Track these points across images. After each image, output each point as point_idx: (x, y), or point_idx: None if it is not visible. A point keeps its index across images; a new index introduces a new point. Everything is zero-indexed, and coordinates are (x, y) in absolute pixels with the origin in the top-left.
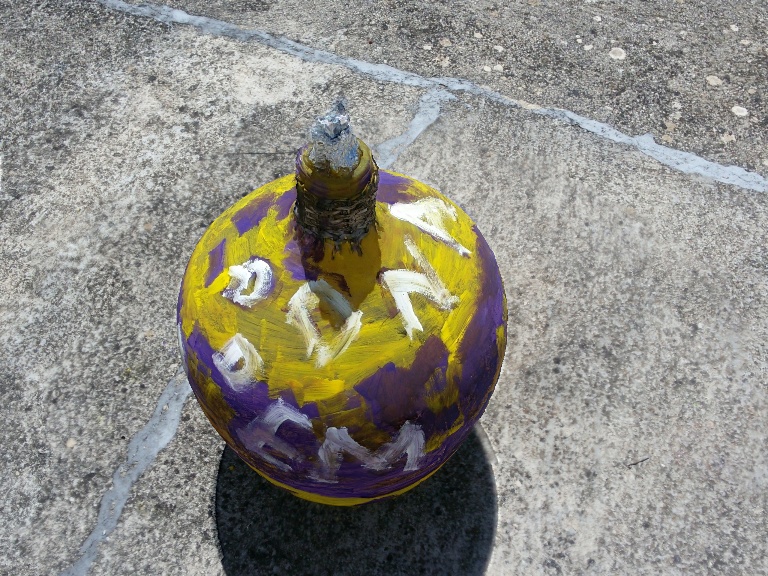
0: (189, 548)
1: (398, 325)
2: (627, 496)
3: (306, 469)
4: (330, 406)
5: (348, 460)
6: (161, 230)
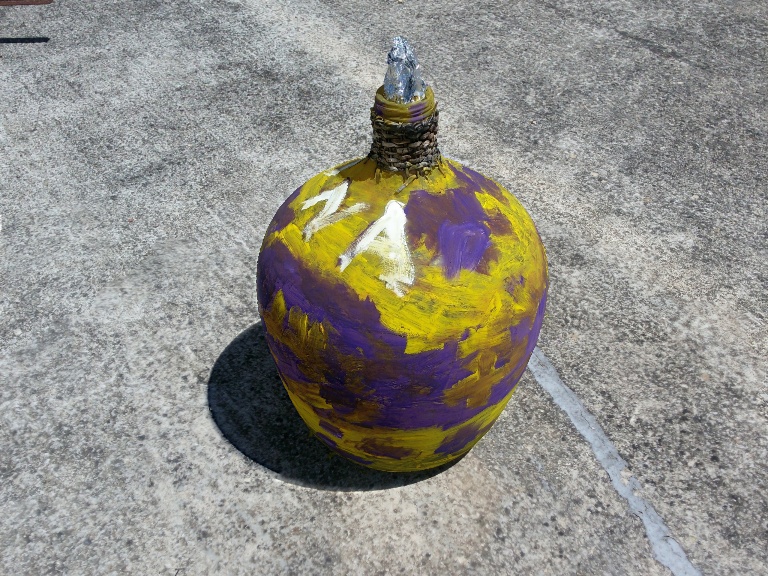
0: None
1: None
2: (161, 548)
3: None
4: None
5: None
6: (696, 383)
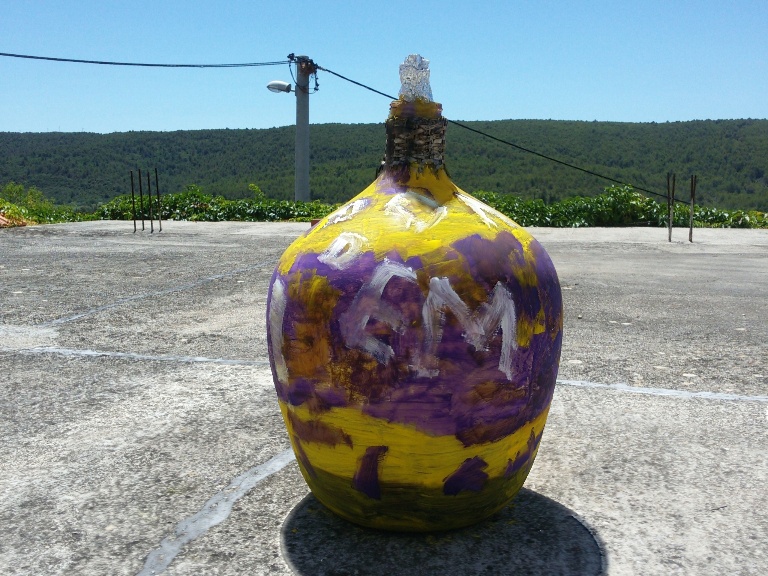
0: (256, 575)
1: (477, 218)
2: (721, 525)
3: (408, 348)
4: (431, 258)
5: (450, 323)
6: (197, 432)
